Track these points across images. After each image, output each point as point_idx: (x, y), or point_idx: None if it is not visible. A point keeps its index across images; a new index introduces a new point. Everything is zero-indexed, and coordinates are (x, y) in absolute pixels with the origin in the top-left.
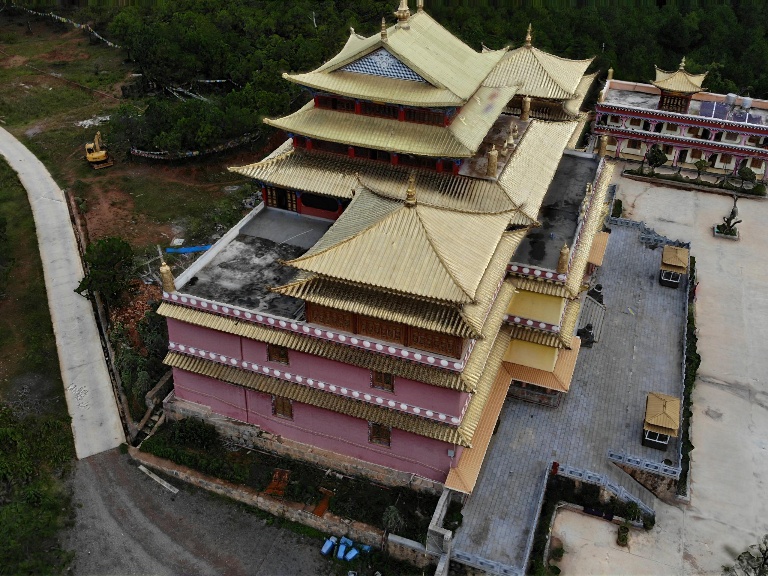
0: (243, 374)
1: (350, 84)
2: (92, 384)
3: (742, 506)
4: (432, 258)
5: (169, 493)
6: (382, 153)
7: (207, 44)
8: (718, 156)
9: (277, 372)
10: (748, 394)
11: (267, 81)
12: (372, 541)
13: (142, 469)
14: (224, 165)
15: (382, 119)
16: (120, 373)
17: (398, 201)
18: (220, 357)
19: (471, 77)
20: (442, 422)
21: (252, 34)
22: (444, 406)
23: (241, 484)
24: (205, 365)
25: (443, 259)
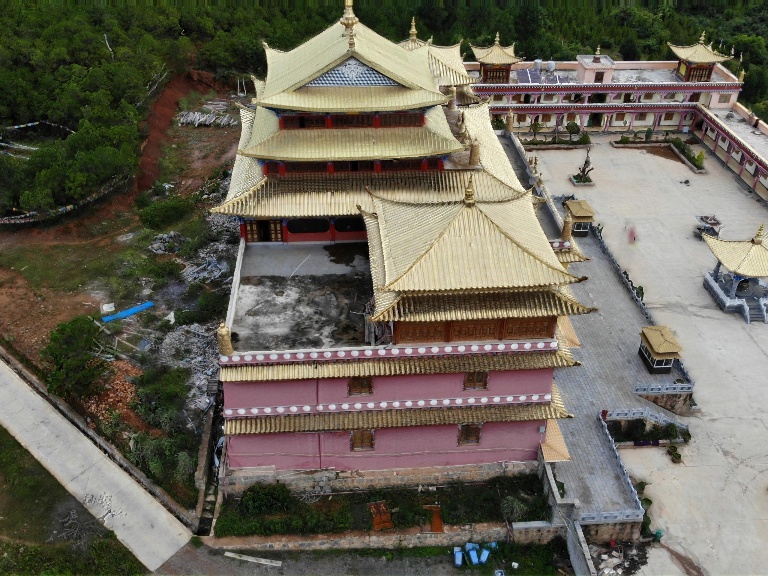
0: (320, 418)
1: (322, 99)
2: (111, 487)
3: (735, 399)
4: (514, 249)
5: (273, 568)
6: (364, 163)
7: (5, 85)
8: (540, 117)
9: (358, 405)
10: (682, 309)
11: (105, 115)
12: (496, 536)
13: (230, 555)
14: (102, 214)
15: (357, 129)
16: (137, 465)
17: (448, 204)
18: (290, 408)
19: (424, 74)
20: (535, 402)
21: (43, 67)
22: (537, 387)
23: (345, 531)
24: (274, 422)
25: (525, 248)
